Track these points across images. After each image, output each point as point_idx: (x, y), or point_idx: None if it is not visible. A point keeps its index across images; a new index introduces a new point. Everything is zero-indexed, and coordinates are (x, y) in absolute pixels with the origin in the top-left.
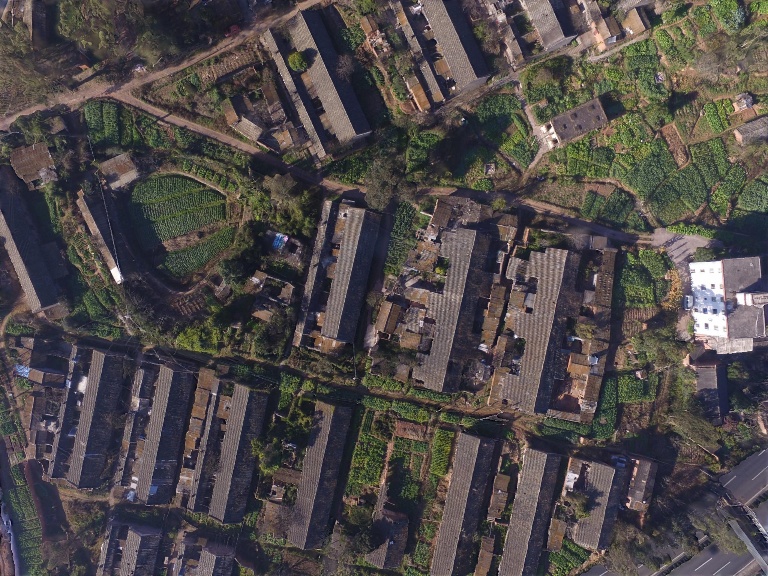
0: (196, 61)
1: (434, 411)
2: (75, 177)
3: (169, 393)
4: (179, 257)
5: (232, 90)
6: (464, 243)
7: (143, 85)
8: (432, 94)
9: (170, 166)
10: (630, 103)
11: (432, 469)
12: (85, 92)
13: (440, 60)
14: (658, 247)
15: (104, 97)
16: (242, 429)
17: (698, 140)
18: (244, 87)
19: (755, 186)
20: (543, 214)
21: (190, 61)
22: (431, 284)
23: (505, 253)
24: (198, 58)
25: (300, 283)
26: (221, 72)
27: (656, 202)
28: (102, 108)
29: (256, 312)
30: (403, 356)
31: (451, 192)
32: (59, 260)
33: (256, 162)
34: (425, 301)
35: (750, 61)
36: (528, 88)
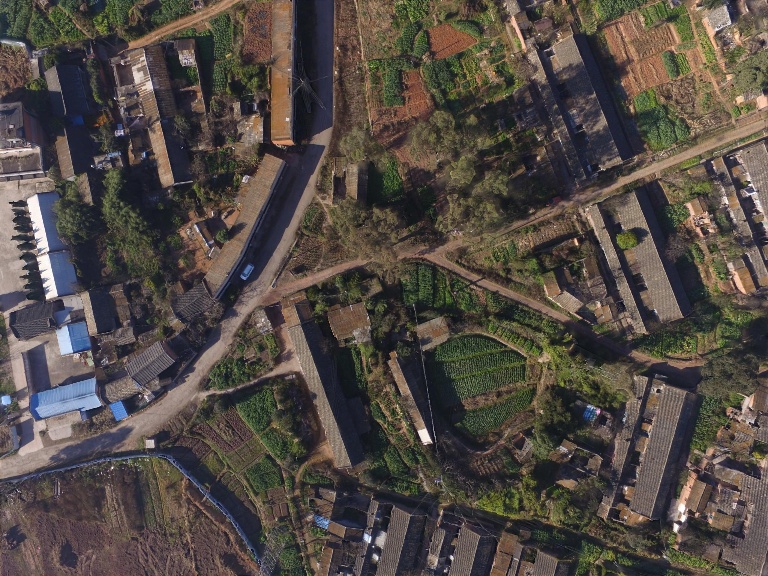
0: (513, 228)
1: None
2: (387, 337)
3: (474, 557)
4: (477, 416)
5: (551, 261)
6: None
7: (460, 250)
8: (758, 278)
9: (476, 328)
10: None
11: None
12: (398, 252)
13: None
14: None
15: (418, 258)
16: None
17: None
18: (564, 258)
19: None
20: None
21: (507, 228)
22: (741, 464)
23: None
24: (515, 225)
25: (608, 455)
26: (538, 241)
27: None
28: (418, 270)
29: (561, 480)
30: (719, 540)
31: (762, 371)
32: (363, 416)
33: (567, 330)
34: (738, 483)
35: None
36: None
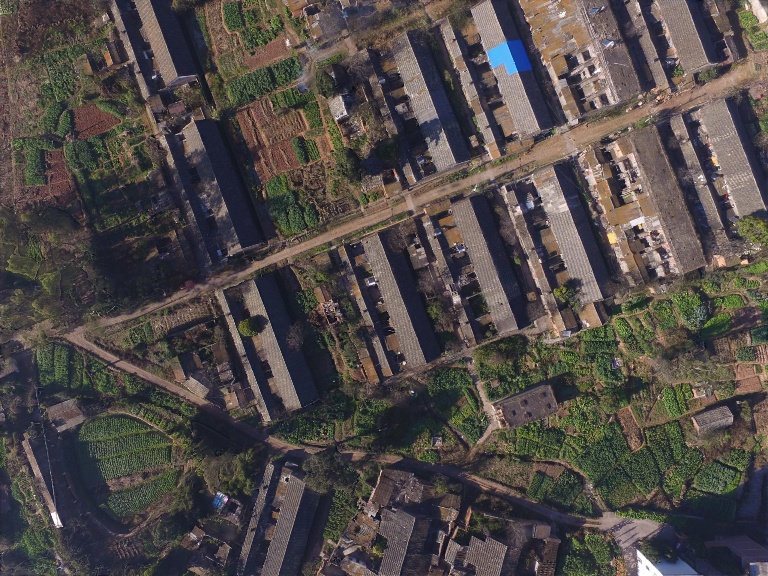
0: (150, 310)
1: None
2: (23, 417)
3: None
4: (122, 497)
5: (183, 345)
6: (403, 527)
7: (96, 331)
8: (382, 368)
9: (118, 408)
10: (585, 386)
11: None
12: (39, 331)
13: (392, 335)
14: (605, 532)
15: (57, 338)
16: None
17: (654, 423)
18: (195, 343)
19: (712, 468)
20: (488, 492)
21: (144, 310)
22: (369, 557)
23: (445, 534)
24: (152, 307)
25: (238, 543)
26: (174, 323)
27: (606, 487)
28: (54, 351)
29: (192, 568)
30: None
31: (397, 460)
32: (2, 495)
33: (203, 414)
34: None
35: (712, 352)
36: (480, 366)
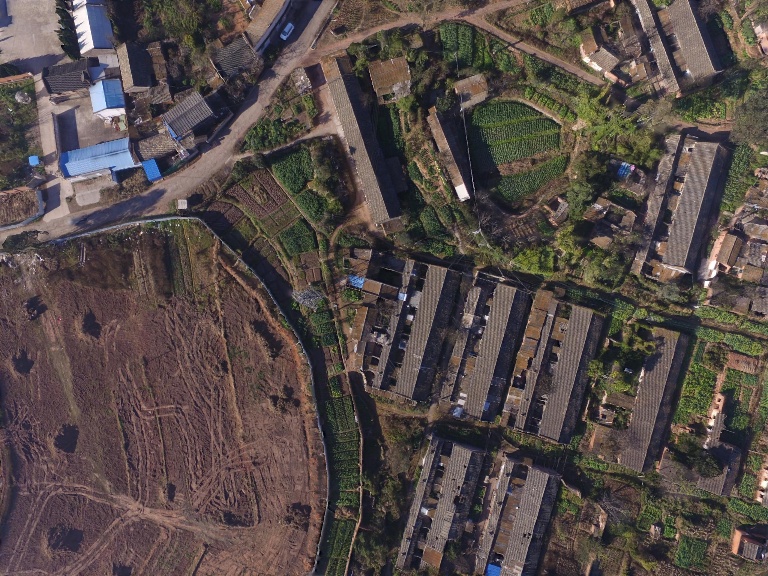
0: None
1: (767, 345)
2: (426, 94)
3: (510, 311)
4: (512, 182)
5: (588, 22)
6: None
7: (499, 11)
8: None
9: (513, 92)
10: None
11: (764, 402)
12: (438, 14)
13: None
14: None
15: (457, 20)
16: (583, 350)
17: None
18: (600, 20)
19: None
20: None
21: None
22: None
23: None
24: None
25: None
26: (575, 4)
27: None
28: (458, 30)
29: (596, 238)
30: (750, 287)
31: None
32: (400, 175)
33: None
34: (767, 237)
35: None
36: None
